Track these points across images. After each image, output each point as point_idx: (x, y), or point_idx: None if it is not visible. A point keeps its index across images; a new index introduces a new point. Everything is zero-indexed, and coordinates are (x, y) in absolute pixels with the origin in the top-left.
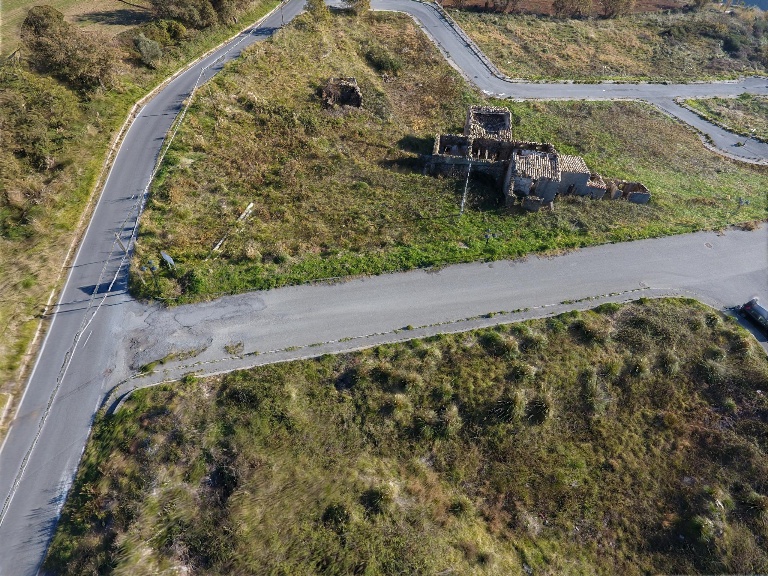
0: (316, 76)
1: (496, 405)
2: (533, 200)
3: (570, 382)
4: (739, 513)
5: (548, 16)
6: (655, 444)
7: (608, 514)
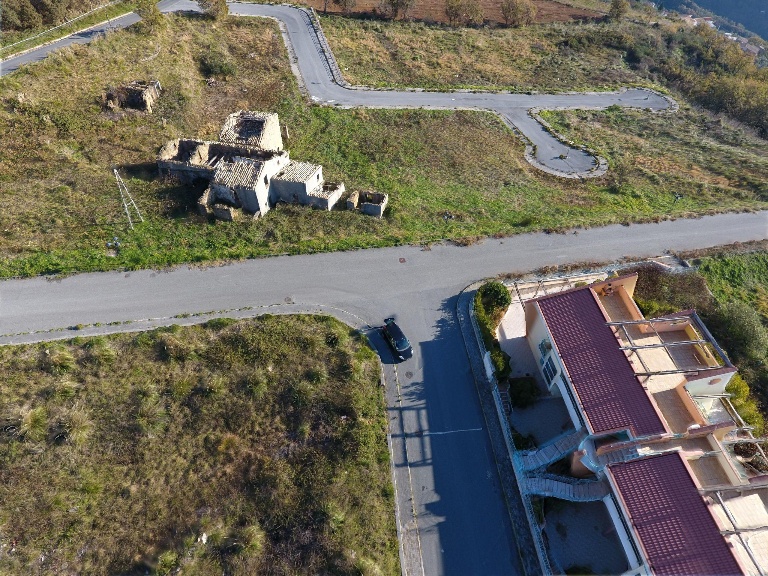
0: (121, 79)
1: (4, 422)
2: (221, 208)
3: (118, 400)
4: (219, 549)
5: (437, 24)
6: (195, 470)
7: (90, 544)
